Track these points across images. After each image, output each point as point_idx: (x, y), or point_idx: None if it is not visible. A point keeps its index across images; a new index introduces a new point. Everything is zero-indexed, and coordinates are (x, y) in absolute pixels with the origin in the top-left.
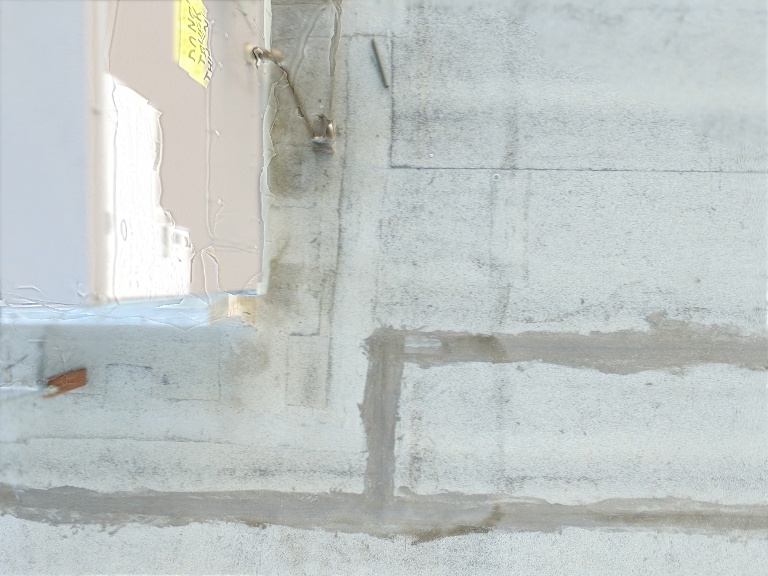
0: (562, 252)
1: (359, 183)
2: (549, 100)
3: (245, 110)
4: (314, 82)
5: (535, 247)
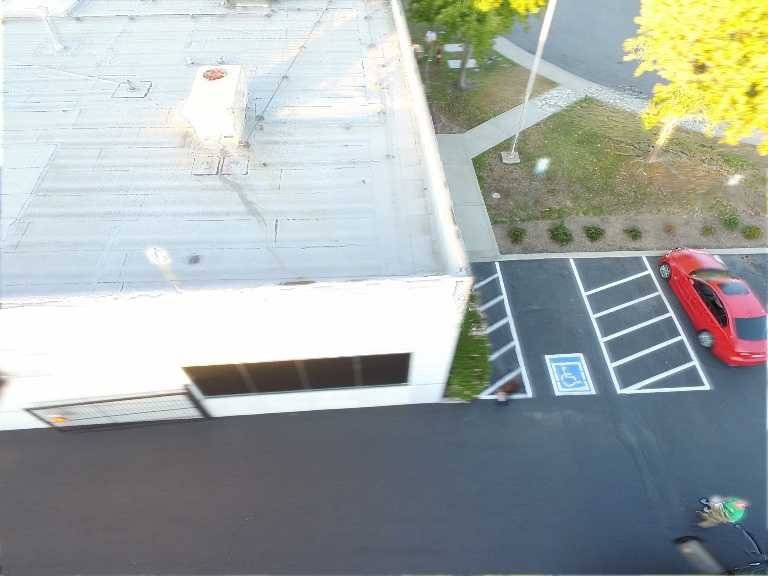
0: None
1: (225, 0)
2: None
3: None
4: None
5: None
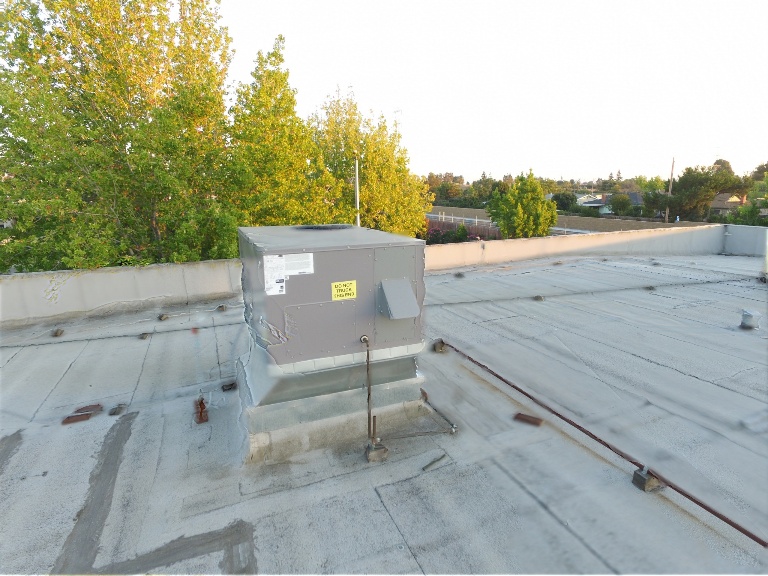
0: None
1: None
2: (481, 556)
3: (339, 329)
4: (406, 444)
5: None
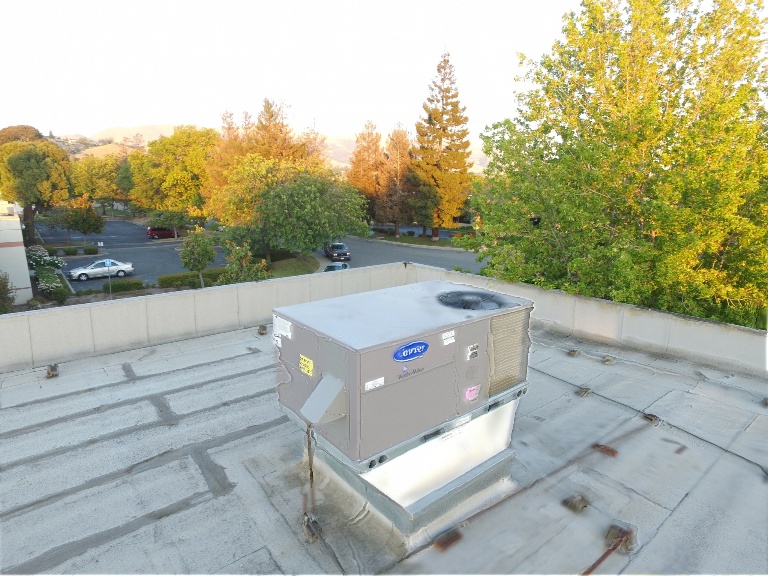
0: (122, 574)
1: None
2: None
3: None
4: (339, 553)
5: (144, 566)
